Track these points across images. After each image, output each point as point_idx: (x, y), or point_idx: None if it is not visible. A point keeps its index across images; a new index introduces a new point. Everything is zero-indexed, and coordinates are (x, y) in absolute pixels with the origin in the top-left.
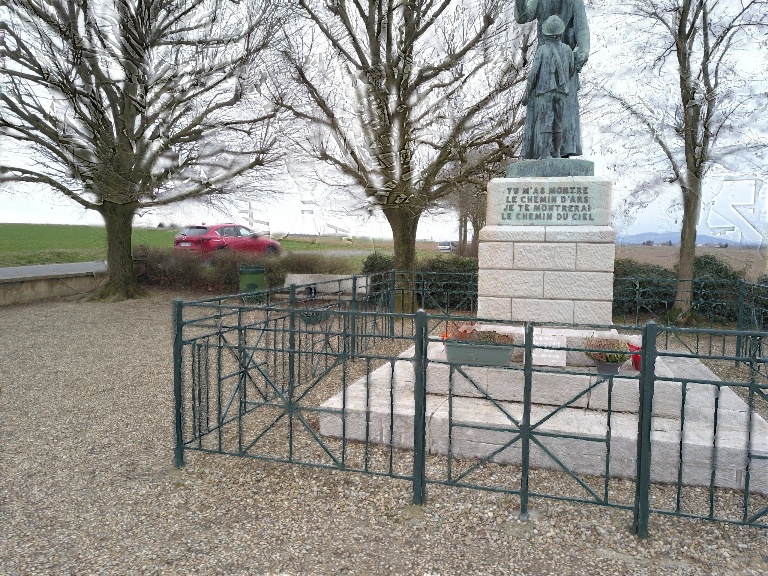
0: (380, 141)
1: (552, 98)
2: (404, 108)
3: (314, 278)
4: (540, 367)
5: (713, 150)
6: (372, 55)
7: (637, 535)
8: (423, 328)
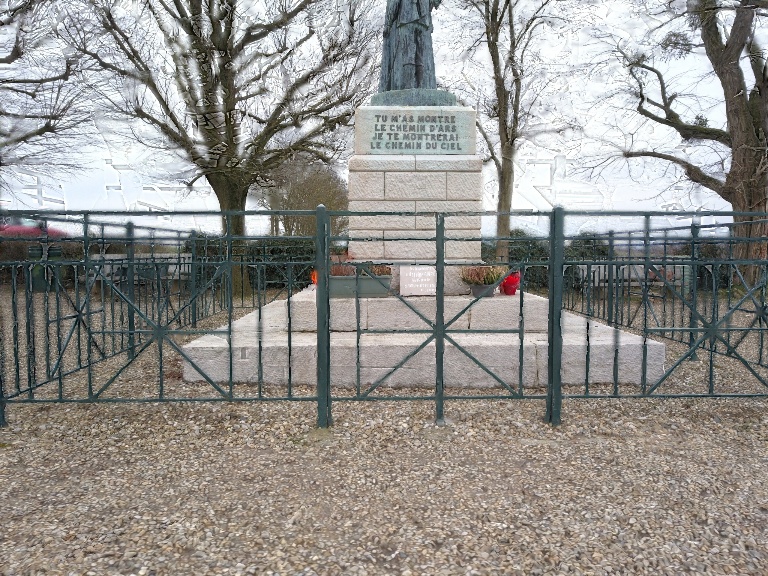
0: (207, 99)
1: (414, 29)
2: (233, 66)
3: None
4: (417, 297)
5: (525, 127)
6: (192, 8)
7: (551, 423)
8: (325, 224)
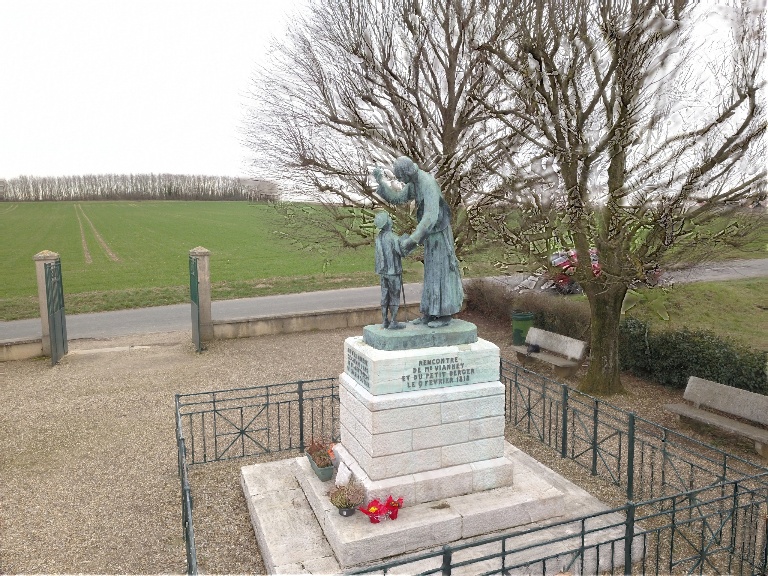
0: None
1: (383, 278)
2: None
3: (546, 335)
4: None
5: None
6: None
7: None
8: None
